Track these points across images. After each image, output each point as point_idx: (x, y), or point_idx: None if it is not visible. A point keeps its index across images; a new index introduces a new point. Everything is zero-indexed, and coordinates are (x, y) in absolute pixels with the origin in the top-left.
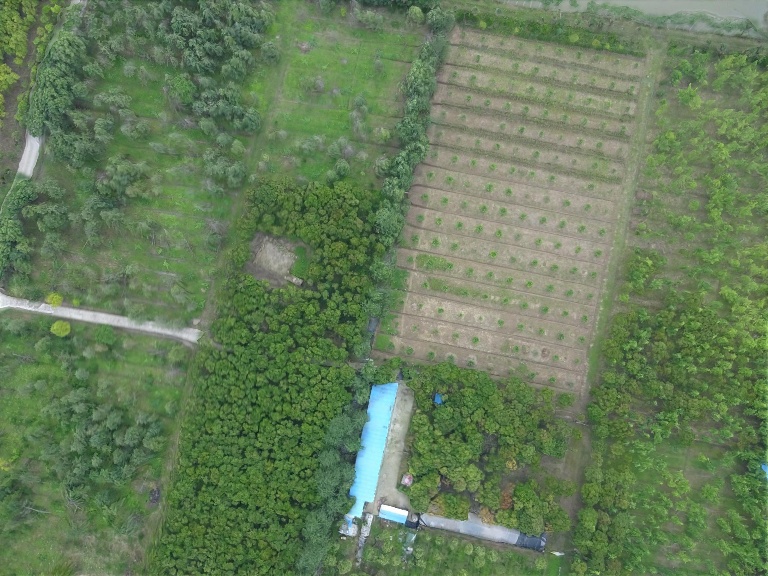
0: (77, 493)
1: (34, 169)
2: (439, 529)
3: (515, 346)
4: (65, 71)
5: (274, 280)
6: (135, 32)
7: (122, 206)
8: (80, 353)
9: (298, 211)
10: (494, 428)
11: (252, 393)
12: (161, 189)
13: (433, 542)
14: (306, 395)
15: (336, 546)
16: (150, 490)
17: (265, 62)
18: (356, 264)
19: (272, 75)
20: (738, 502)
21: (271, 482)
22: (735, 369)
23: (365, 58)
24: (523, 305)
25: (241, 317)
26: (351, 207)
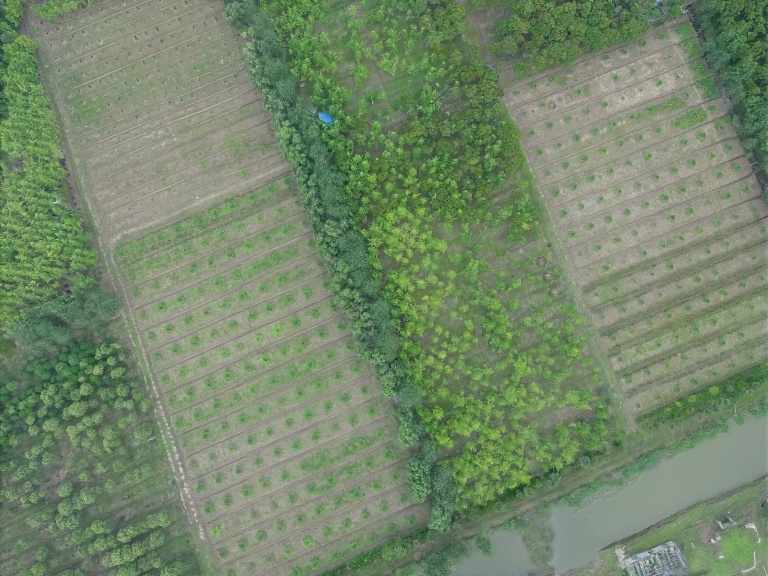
0: None
1: None
2: None
3: None
4: None
5: None
6: None
7: None
8: None
9: None
10: (569, 6)
11: None
12: None
13: None
14: None
15: None
16: None
17: None
18: (764, 65)
19: None
20: None
21: None
22: (399, 184)
23: None
24: None
25: None
26: None
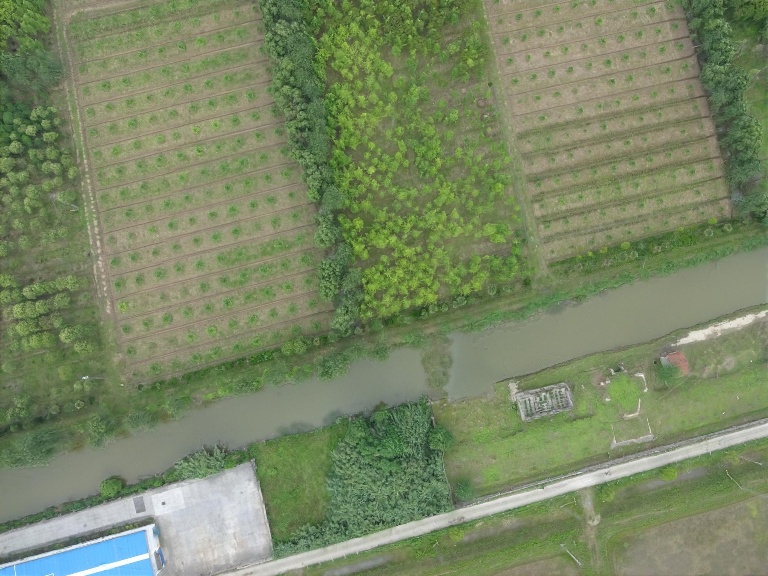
0: None
1: None
2: None
3: None
4: None
5: None
6: None
7: None
8: None
9: None
10: None
11: None
12: None
13: None
14: None
15: None
16: None
17: None
18: None
19: None
20: None
21: None
22: (356, 4)
23: None
24: None
25: None
26: None
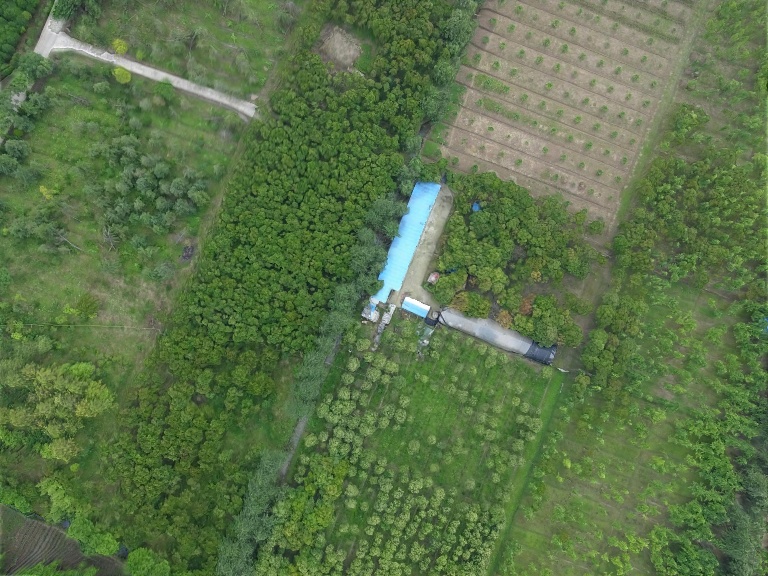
0: (116, 229)
1: None
2: (456, 330)
3: (555, 174)
4: None
5: (336, 71)
6: None
7: None
8: (137, 103)
9: (373, 4)
10: (527, 237)
11: (302, 164)
12: None
13: (450, 337)
14: (354, 174)
15: (358, 323)
16: (185, 246)
17: None
18: (420, 64)
19: None
20: (737, 349)
21: (307, 250)
22: (755, 228)
23: None
24: (569, 137)
25: (302, 93)
26: (425, 9)
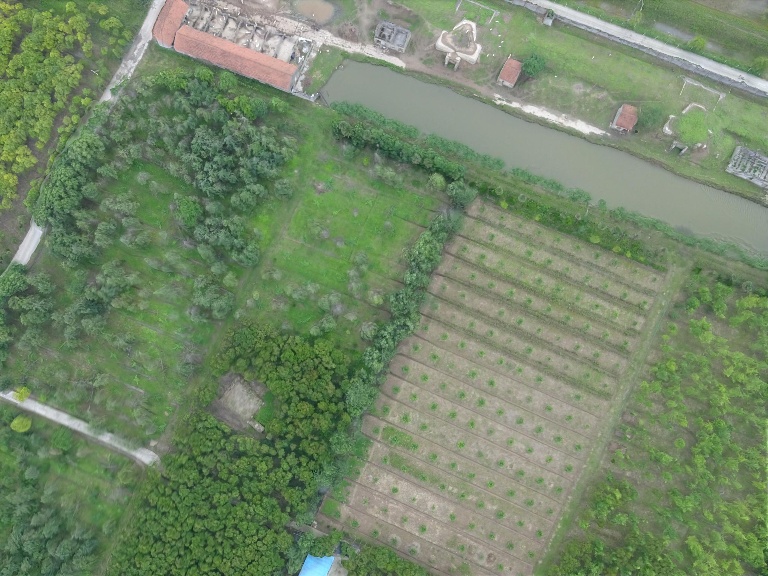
0: None
1: (32, 255)
2: None
3: (461, 545)
4: (79, 170)
5: (237, 420)
6: (156, 142)
7: (106, 313)
8: (35, 451)
9: (273, 361)
10: None
11: (187, 537)
12: (147, 304)
13: None
14: (238, 553)
15: None
16: None
17: (277, 197)
18: (318, 429)
19: (282, 210)
20: None
21: None
22: None
23: (378, 212)
24: (479, 505)
25: (194, 456)
26: (326, 371)
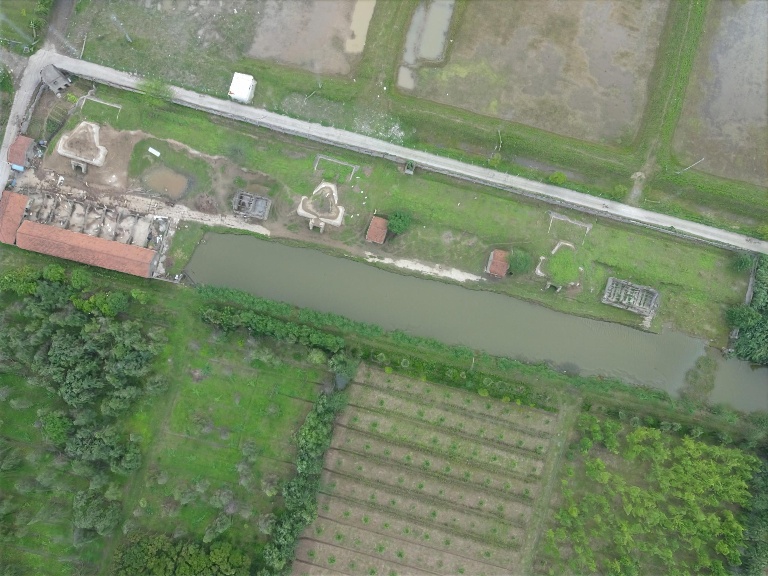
0: None
1: None
2: None
3: None
4: None
5: None
6: (10, 356)
7: None
8: None
9: (169, 575)
10: None
11: None
12: (26, 531)
13: None
14: None
15: None
16: None
17: None
18: None
19: (159, 404)
20: None
21: None
22: None
23: (261, 392)
24: None
25: None
26: None
